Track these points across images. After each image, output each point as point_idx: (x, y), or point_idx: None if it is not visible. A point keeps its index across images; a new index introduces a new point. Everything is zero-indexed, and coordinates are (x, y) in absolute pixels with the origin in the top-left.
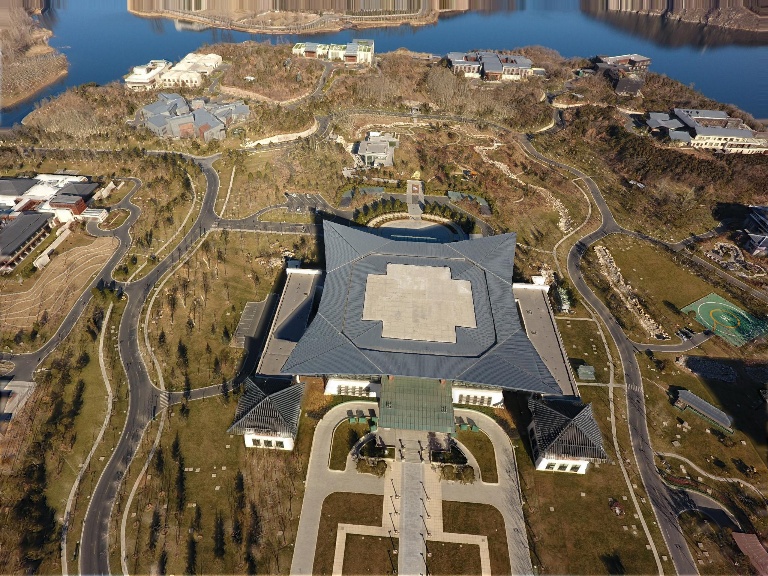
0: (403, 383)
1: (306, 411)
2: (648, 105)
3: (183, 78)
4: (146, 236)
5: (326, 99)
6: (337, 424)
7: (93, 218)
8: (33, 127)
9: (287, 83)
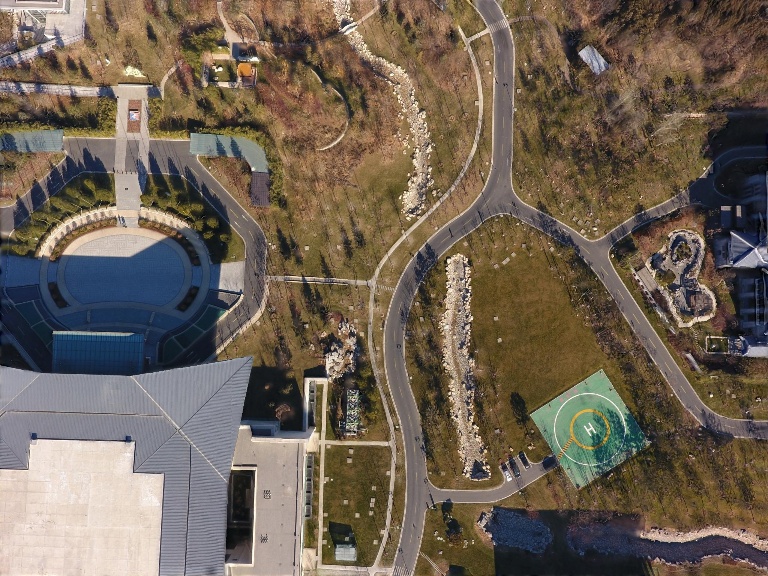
0: None
1: None
2: None
3: None
4: None
5: None
6: None
7: None
8: None
9: None
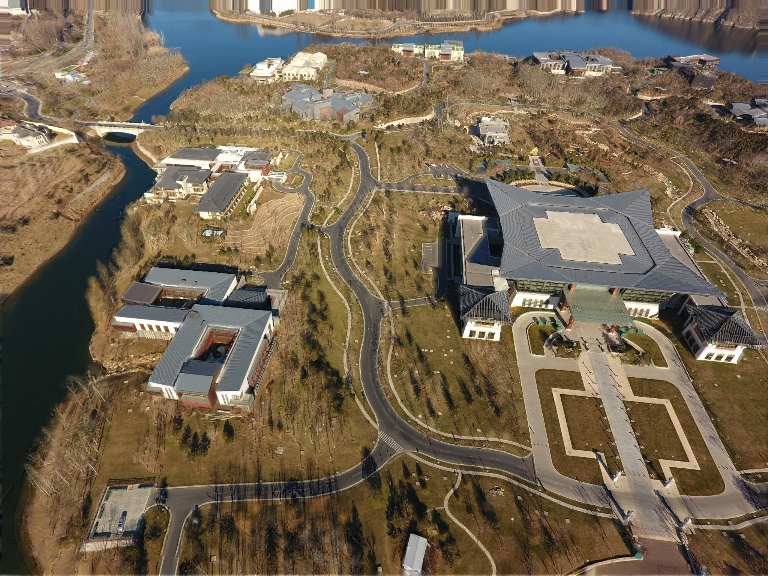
0: (582, 294)
1: None
2: (728, 97)
3: (302, 72)
4: (329, 192)
5: (435, 90)
6: (528, 326)
7: (276, 179)
8: (192, 110)
9: (398, 76)
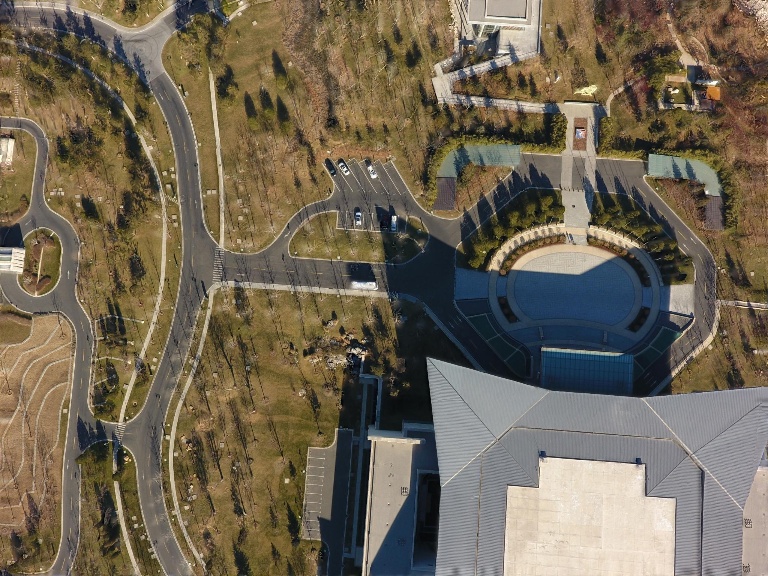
0: None
1: None
2: None
3: None
4: None
5: None
6: None
7: None
8: None
9: None
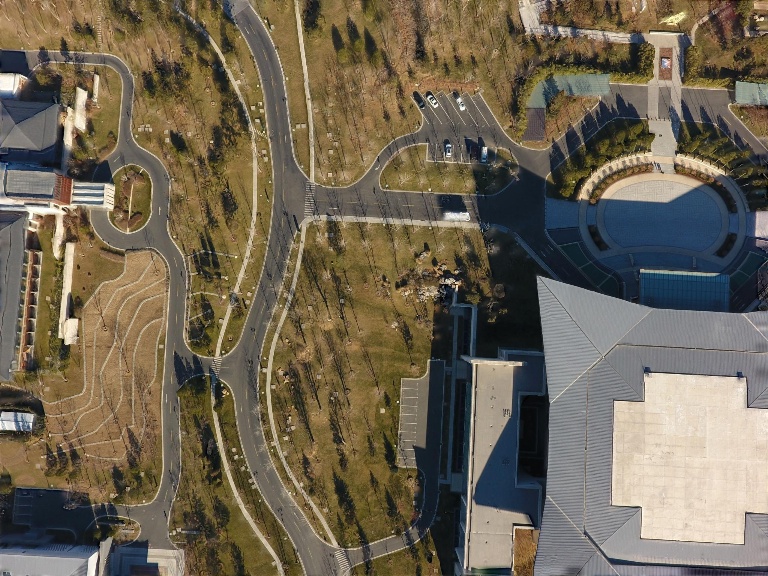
0: None
1: (515, 568)
2: None
3: None
4: None
5: None
6: None
7: None
8: None
9: None
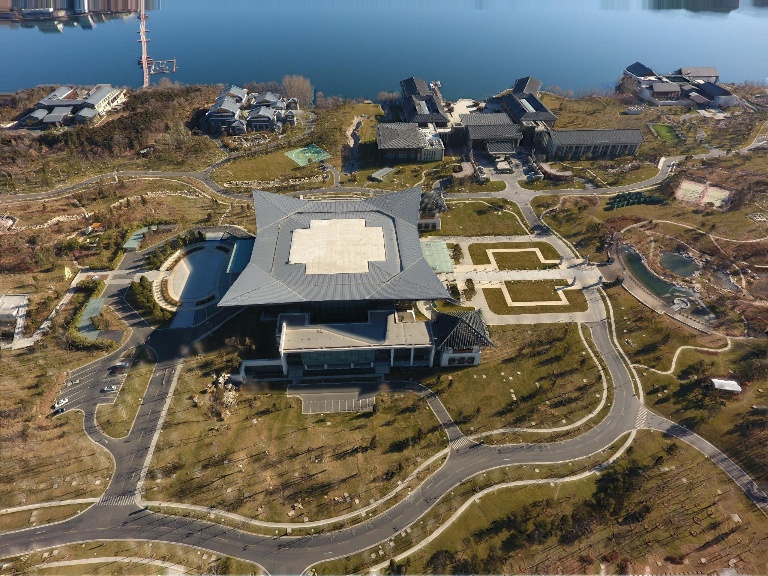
0: None
1: None
2: (7, 114)
3: None
4: None
5: None
6: None
7: None
8: None
9: None
